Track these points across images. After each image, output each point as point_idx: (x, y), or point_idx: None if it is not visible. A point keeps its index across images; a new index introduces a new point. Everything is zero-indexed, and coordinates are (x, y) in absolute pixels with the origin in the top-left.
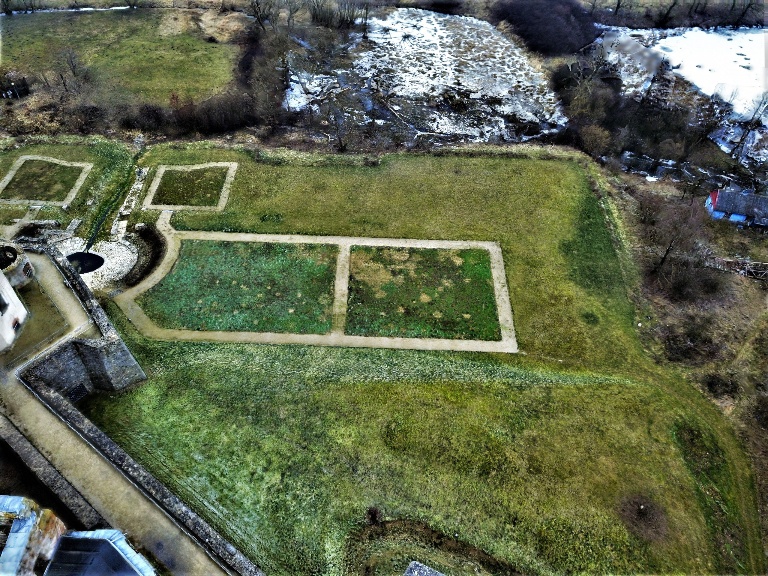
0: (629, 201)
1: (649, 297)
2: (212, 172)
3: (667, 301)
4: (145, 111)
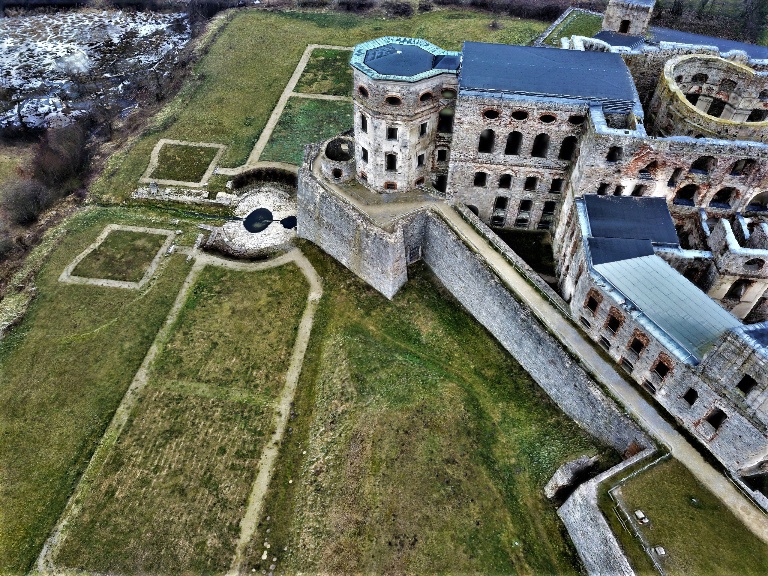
0: (282, 7)
1: (365, 14)
2: (168, 152)
3: (371, 8)
4: (12, 206)
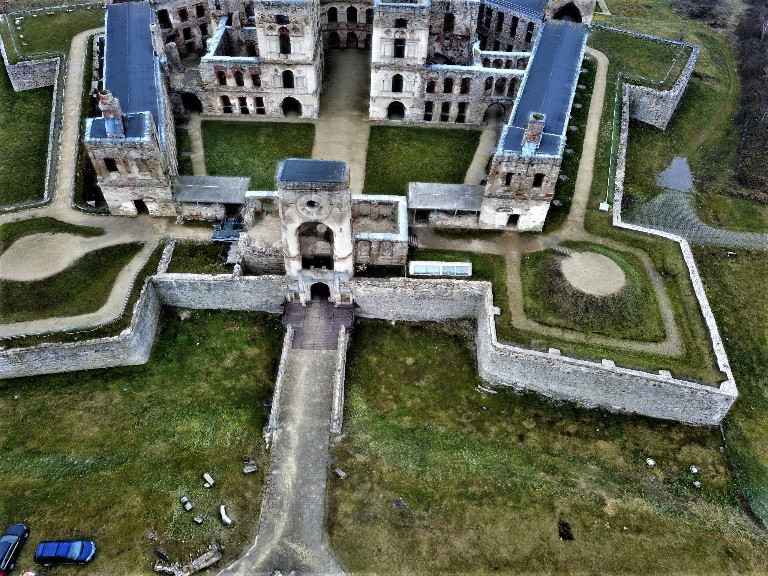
0: None
1: (680, 3)
2: None
3: (690, 2)
4: None
